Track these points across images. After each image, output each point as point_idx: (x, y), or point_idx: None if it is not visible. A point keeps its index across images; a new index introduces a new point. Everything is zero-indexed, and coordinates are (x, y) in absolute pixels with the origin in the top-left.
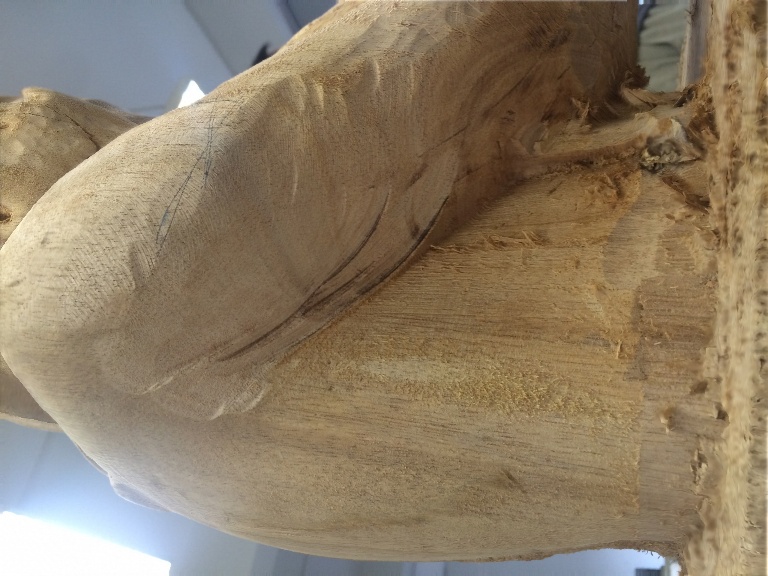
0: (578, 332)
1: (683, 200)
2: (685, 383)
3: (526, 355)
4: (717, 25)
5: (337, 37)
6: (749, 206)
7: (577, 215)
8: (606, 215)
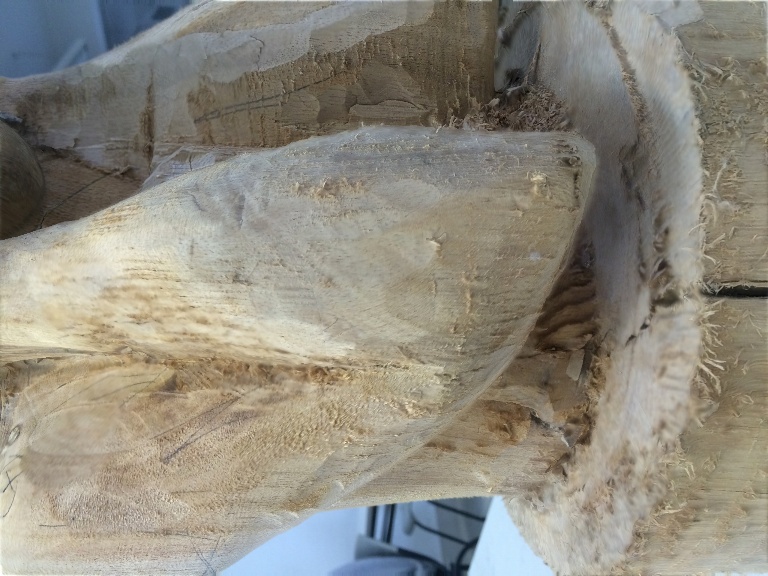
0: (468, 483)
1: (552, 448)
2: (521, 493)
3: (434, 489)
4: (626, 384)
5: (292, 471)
6: (587, 548)
7: (478, 437)
8: (499, 444)
